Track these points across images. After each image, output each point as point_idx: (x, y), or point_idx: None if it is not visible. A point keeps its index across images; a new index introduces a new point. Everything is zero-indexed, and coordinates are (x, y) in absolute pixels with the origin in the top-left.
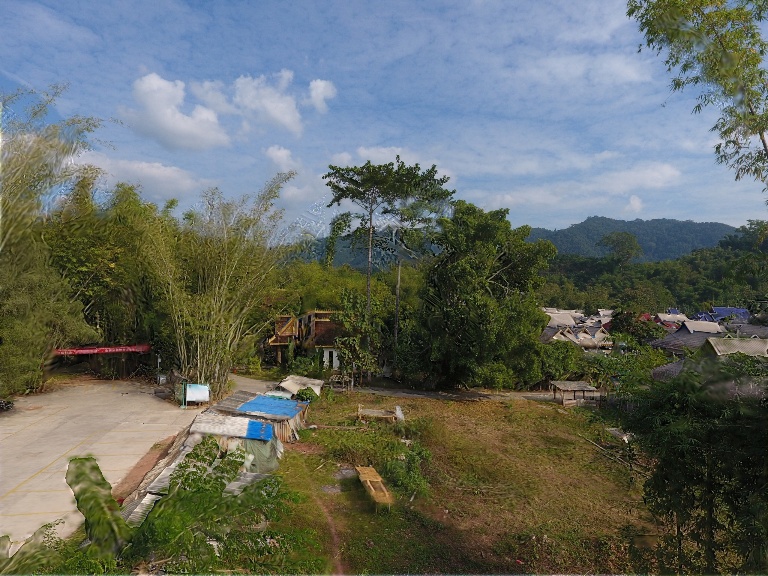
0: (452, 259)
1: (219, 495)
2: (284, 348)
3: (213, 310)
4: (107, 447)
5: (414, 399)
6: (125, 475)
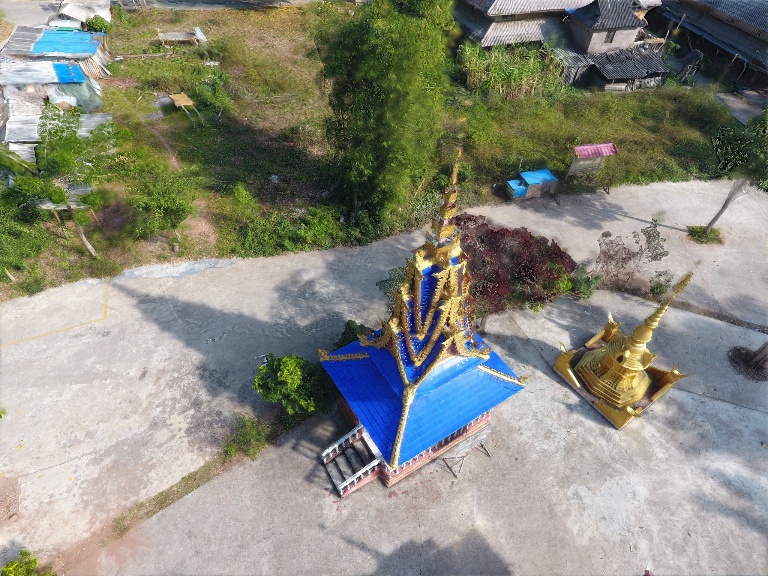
0: None
1: (75, 138)
2: None
3: None
4: None
5: (215, 11)
6: None
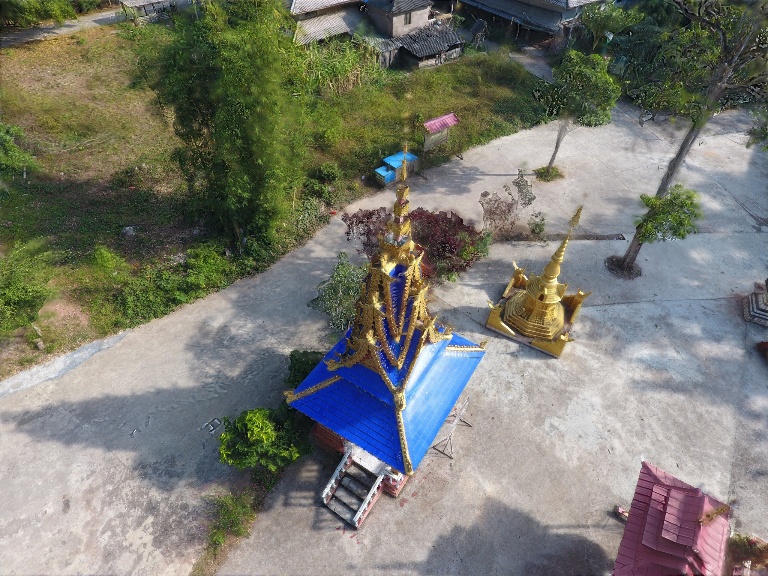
0: None
1: None
2: None
3: None
4: None
5: None
6: None
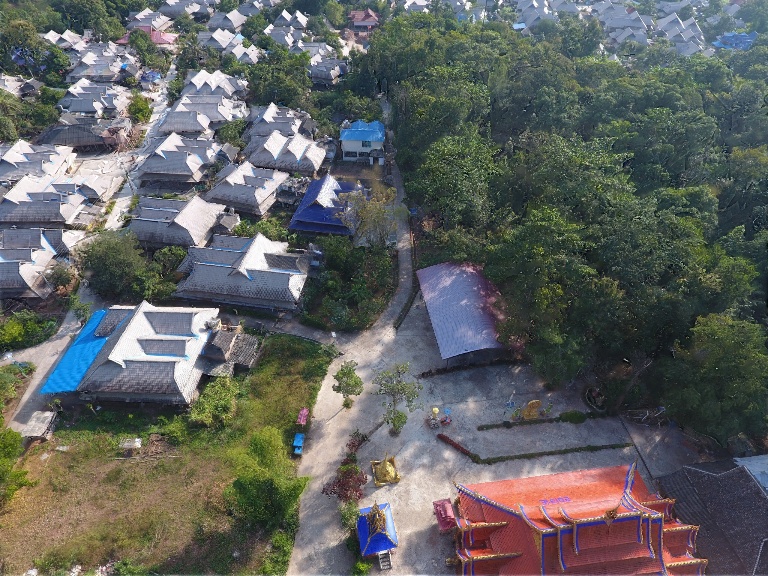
0: None
1: None
2: None
3: None
4: None
5: None
6: None
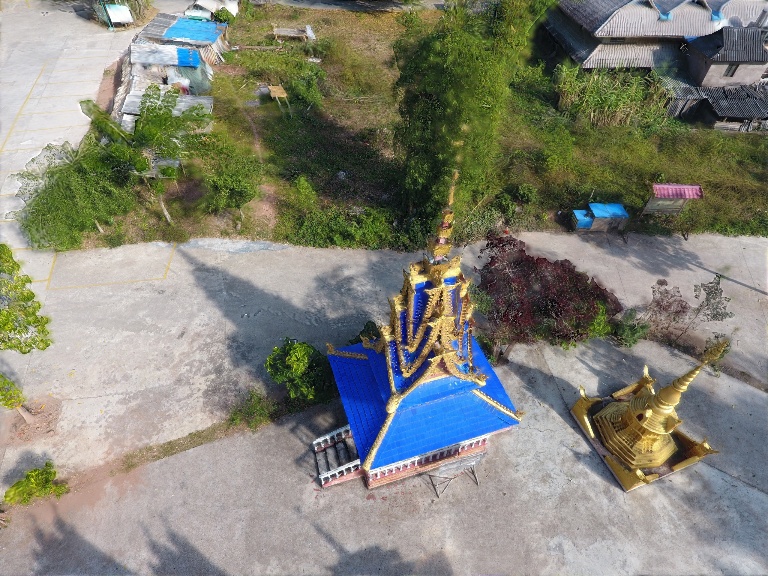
0: None
1: (170, 116)
2: None
3: None
4: (66, 75)
5: (330, 11)
6: (95, 98)
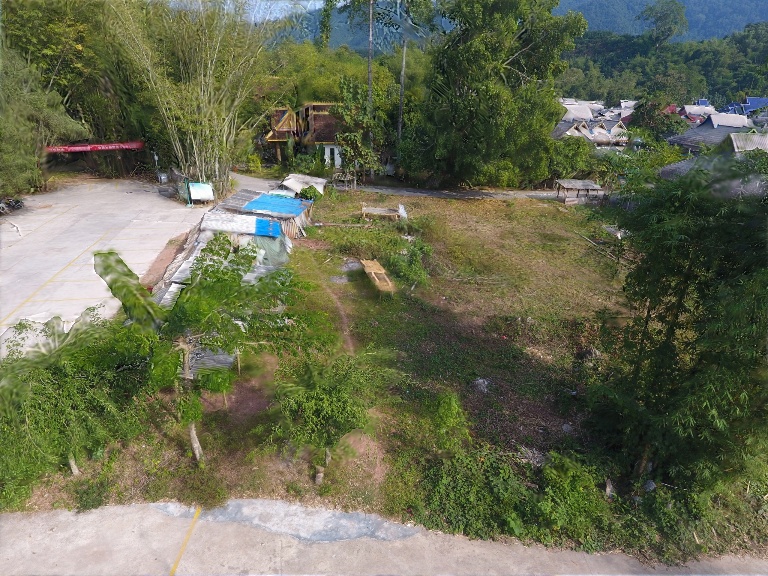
0: (465, 38)
1: (238, 284)
2: (283, 145)
3: (202, 102)
4: (125, 243)
5: (417, 198)
6: (148, 267)
